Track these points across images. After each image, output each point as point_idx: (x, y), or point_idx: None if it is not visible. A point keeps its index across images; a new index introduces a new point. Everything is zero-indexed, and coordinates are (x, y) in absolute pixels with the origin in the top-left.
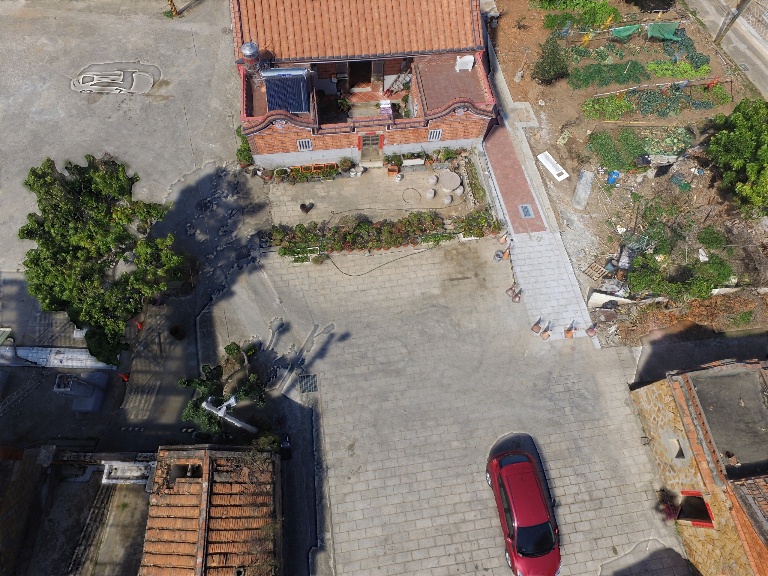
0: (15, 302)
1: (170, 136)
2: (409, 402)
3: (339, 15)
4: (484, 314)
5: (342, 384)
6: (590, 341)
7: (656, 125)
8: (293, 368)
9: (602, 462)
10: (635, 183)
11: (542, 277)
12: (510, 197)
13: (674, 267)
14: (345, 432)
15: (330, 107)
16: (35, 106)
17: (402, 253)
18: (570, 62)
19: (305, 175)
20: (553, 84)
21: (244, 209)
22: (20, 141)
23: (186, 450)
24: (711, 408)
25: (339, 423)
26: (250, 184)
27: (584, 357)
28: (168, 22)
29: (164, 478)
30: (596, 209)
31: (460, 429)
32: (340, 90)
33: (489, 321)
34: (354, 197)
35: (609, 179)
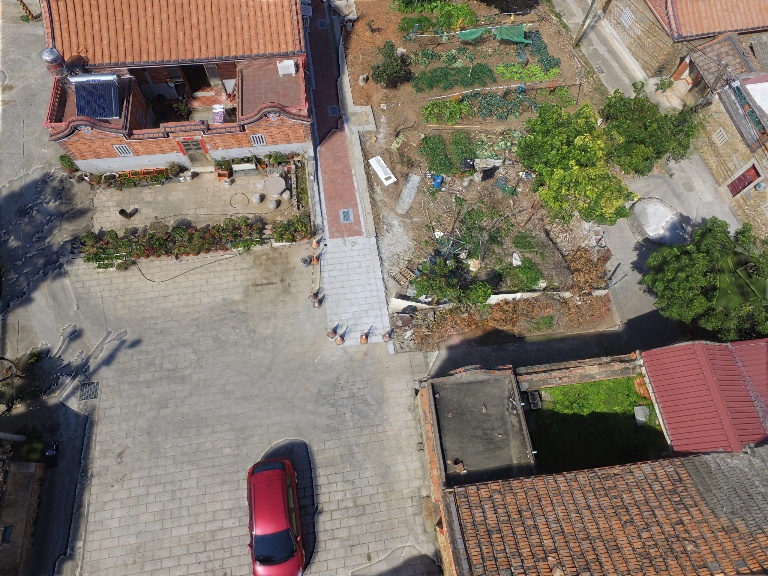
0: None
1: (3, 141)
2: (188, 409)
3: (156, 20)
4: (282, 320)
5: (123, 391)
6: (385, 346)
7: (493, 128)
8: (77, 375)
9: (373, 468)
10: (461, 187)
11: (348, 282)
12: (333, 202)
13: (486, 271)
14: (117, 439)
15: (167, 112)
16: None
17: (211, 259)
18: (419, 65)
19: (132, 180)
20: (398, 87)
21: (64, 215)
22: None
23: None
24: (450, 415)
25: (113, 430)
26: (75, 189)
27: (375, 362)
28: (23, 26)
29: None
30: (418, 213)
31: (235, 436)
32: (183, 94)
33: (286, 327)
34: (180, 202)
35: (434, 183)
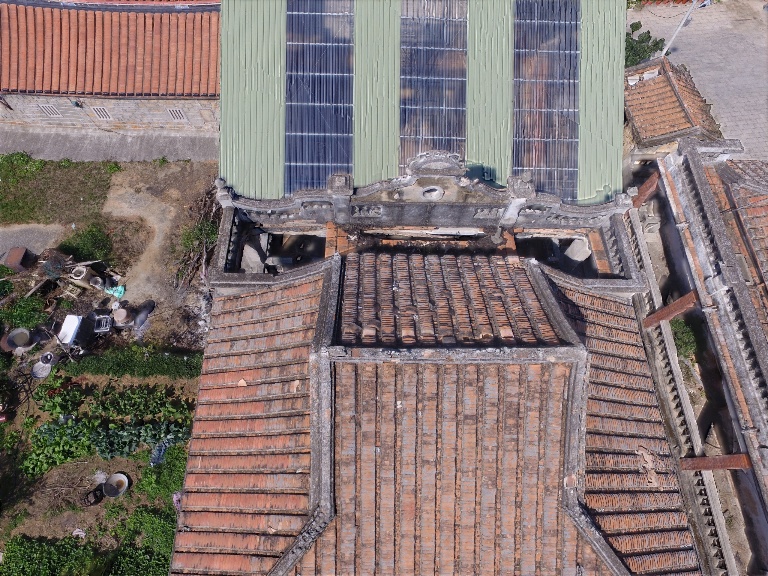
0: None
1: None
2: (736, 83)
3: None
4: None
5: None
6: None
7: None
8: None
9: None
10: None
11: None
12: None
13: None
14: None
15: None
16: None
17: (696, 5)
18: None
19: None
20: None
21: None
22: None
23: (643, 63)
24: None
25: None
26: None
27: None
28: None
29: (627, 84)
30: None
31: None
32: None
33: None
34: None
35: None
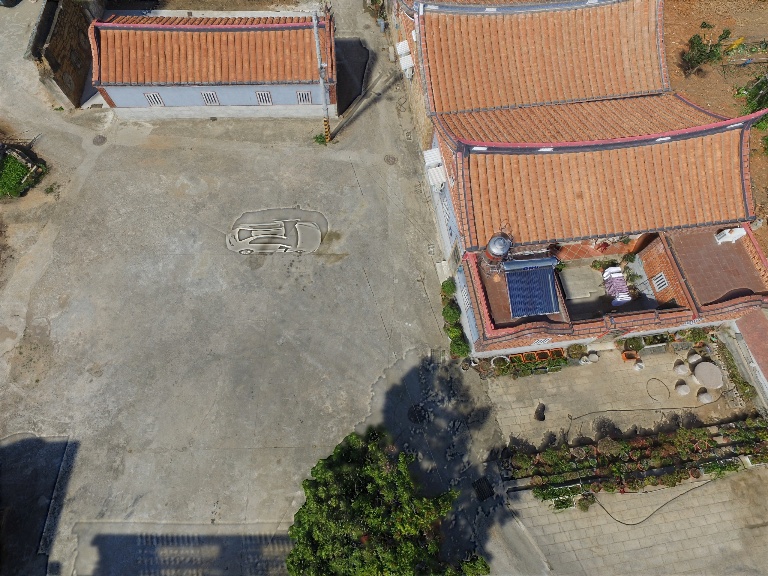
0: (218, 571)
1: (356, 313)
2: None
3: (584, 183)
4: None
5: None
6: None
7: None
8: None
9: None
10: None
11: None
12: None
13: None
14: None
15: None
16: (190, 275)
17: (681, 488)
18: None
19: (529, 366)
20: None
21: (467, 419)
22: (181, 326)
23: None
24: None
25: None
26: (466, 381)
27: None
28: (322, 151)
29: None
30: None
31: None
32: None
33: None
34: (590, 394)
35: None
